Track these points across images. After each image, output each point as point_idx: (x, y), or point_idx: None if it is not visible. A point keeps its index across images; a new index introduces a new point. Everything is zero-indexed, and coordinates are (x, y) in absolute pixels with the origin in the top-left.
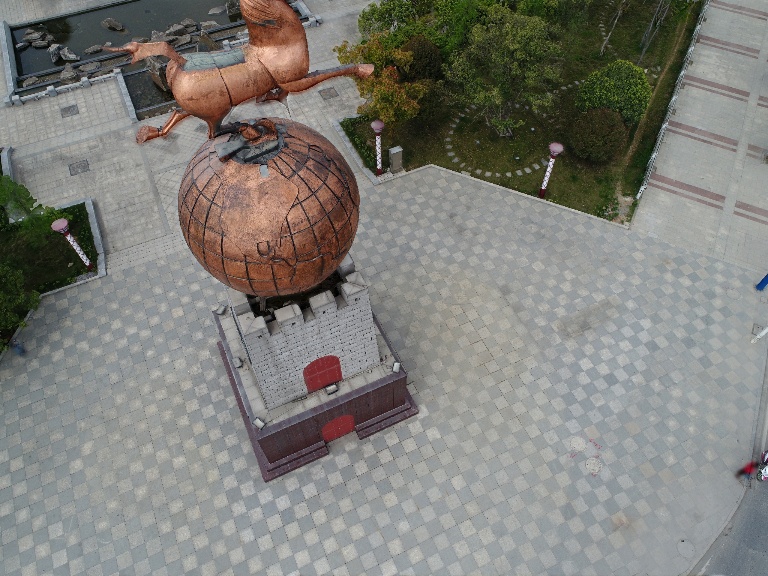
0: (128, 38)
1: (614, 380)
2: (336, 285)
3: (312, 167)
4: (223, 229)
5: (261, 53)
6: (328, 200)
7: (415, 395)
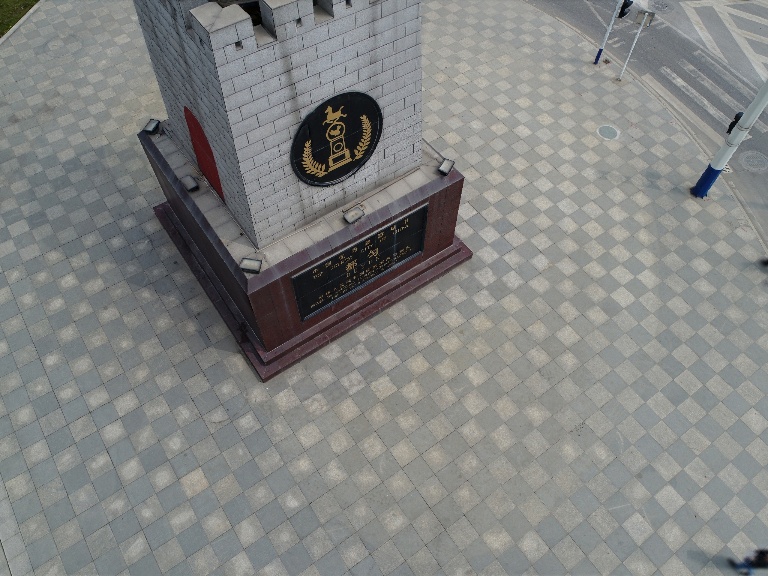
0: None
1: None
2: None
3: None
4: None
5: None
6: None
7: None
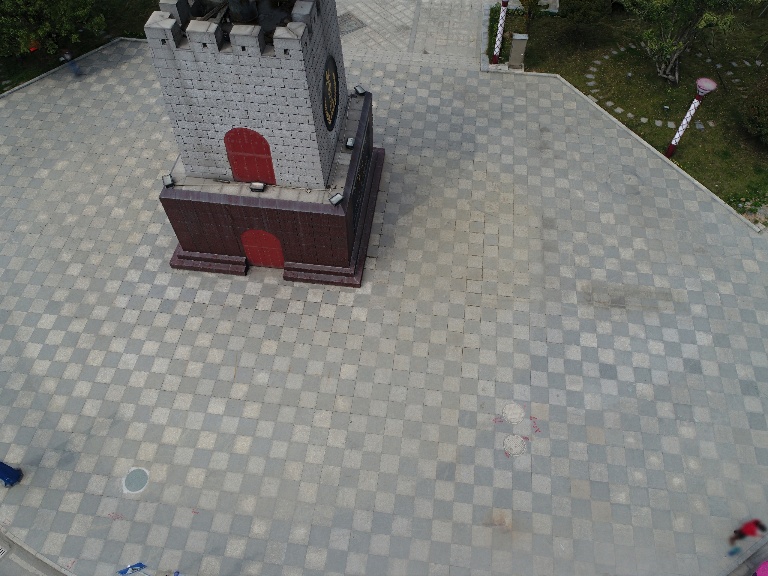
0: None
1: (612, 374)
2: None
3: None
4: None
5: None
6: None
7: (370, 270)
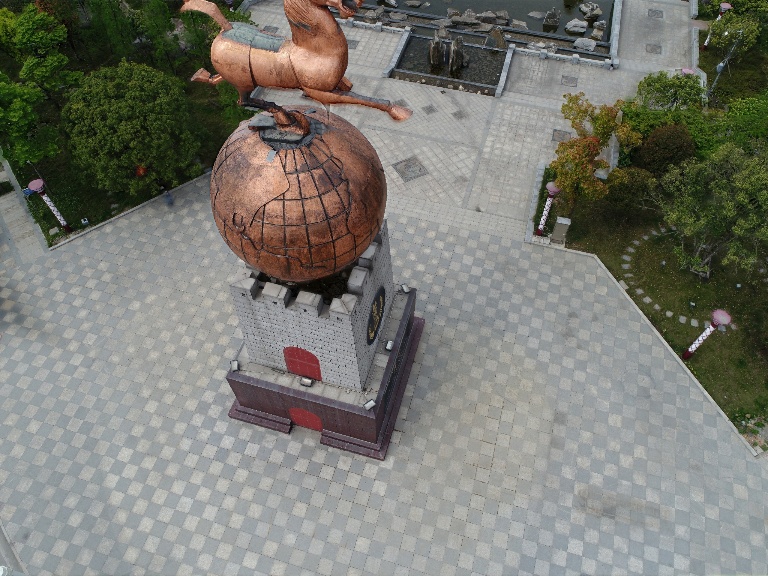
0: (446, 6)
1: None
2: (338, 296)
3: (317, 176)
4: (219, 185)
5: (294, 51)
6: (314, 212)
7: (395, 444)
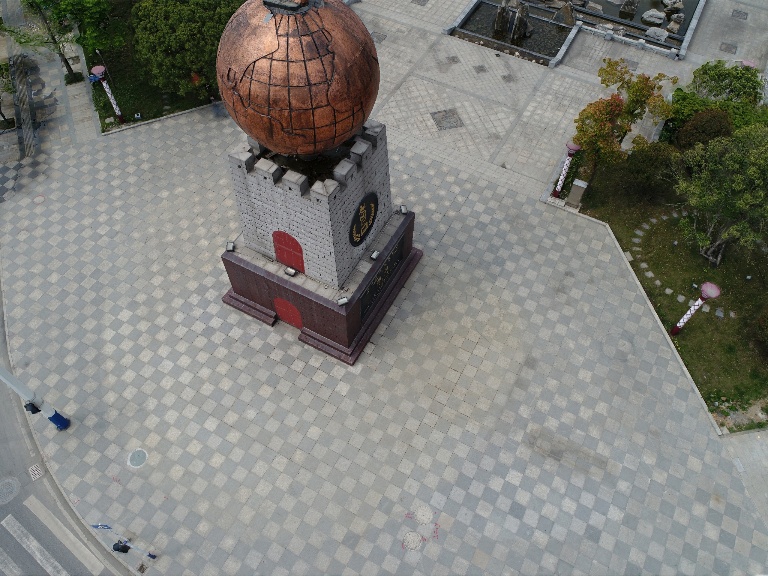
0: None
1: (519, 514)
2: None
3: (305, 42)
4: (222, 43)
5: None
6: (297, 76)
7: (366, 354)
